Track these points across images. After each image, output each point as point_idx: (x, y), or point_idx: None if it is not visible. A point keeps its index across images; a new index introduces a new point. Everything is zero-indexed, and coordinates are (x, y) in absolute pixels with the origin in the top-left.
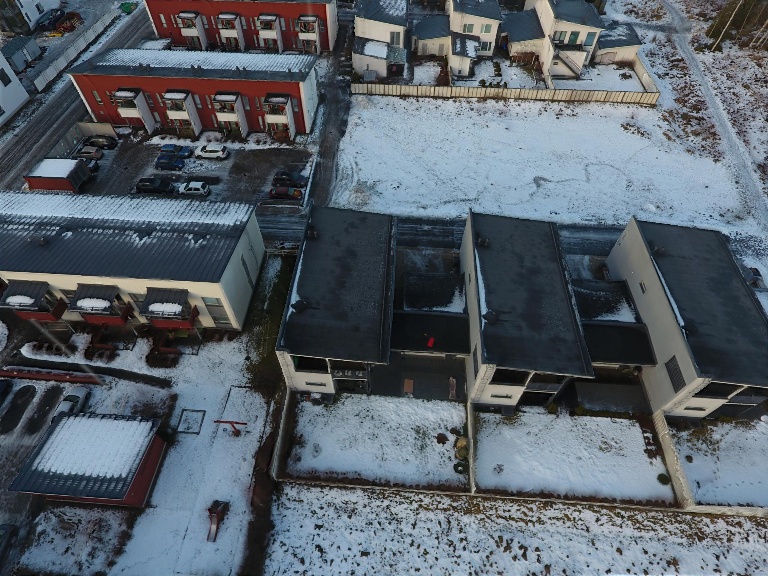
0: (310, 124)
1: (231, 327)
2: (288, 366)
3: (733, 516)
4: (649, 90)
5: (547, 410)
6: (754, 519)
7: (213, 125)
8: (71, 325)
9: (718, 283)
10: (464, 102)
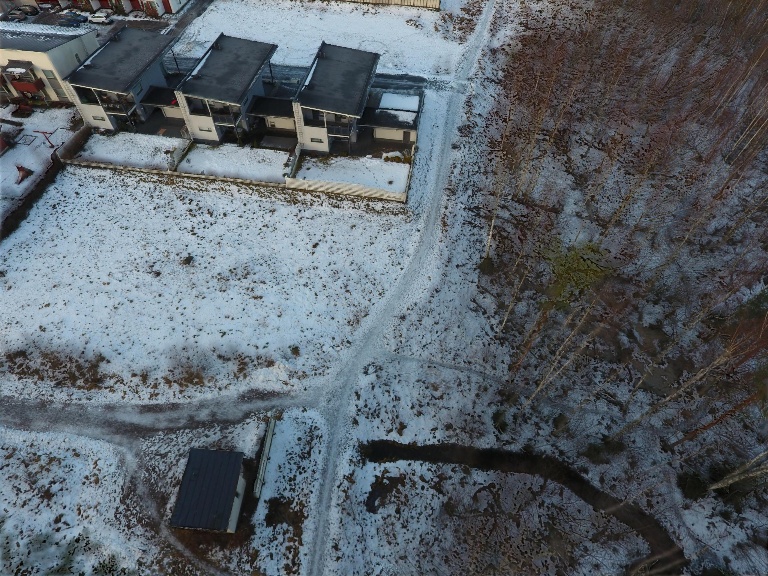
0: (178, 8)
1: (69, 101)
2: (74, 96)
3: (316, 192)
4: (443, 1)
5: (238, 145)
6: (328, 194)
7: (108, 5)
8: None
9: (351, 73)
10: (298, 1)
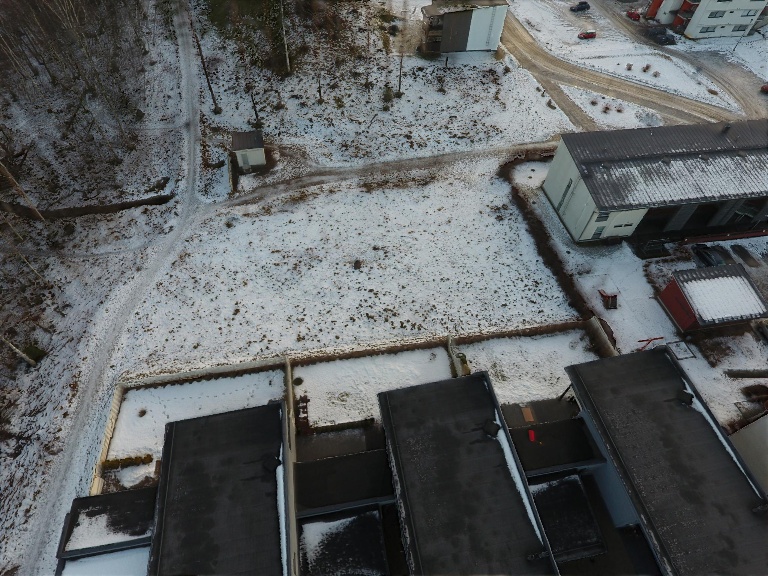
0: None
1: None
2: None
3: None
4: None
5: None
6: None
7: None
8: None
9: (199, 569)
10: None
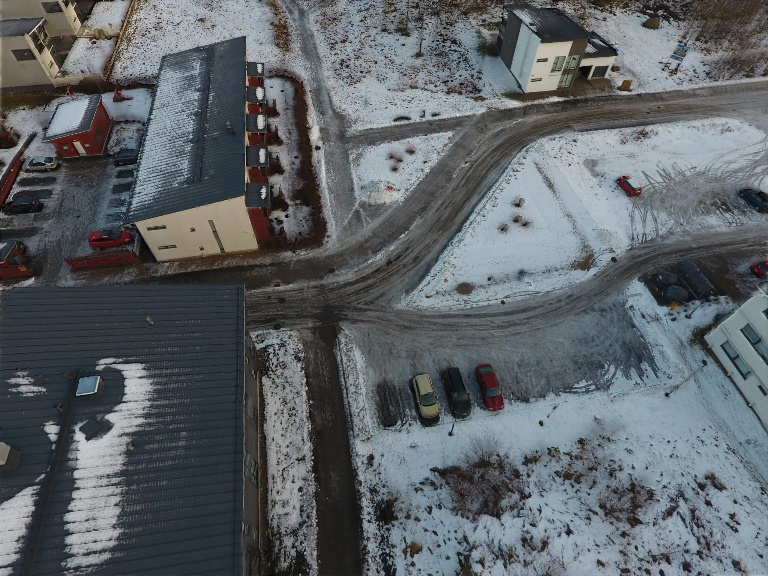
0: None
1: None
2: None
3: None
4: None
5: (86, 20)
6: None
7: None
8: None
9: None
10: None
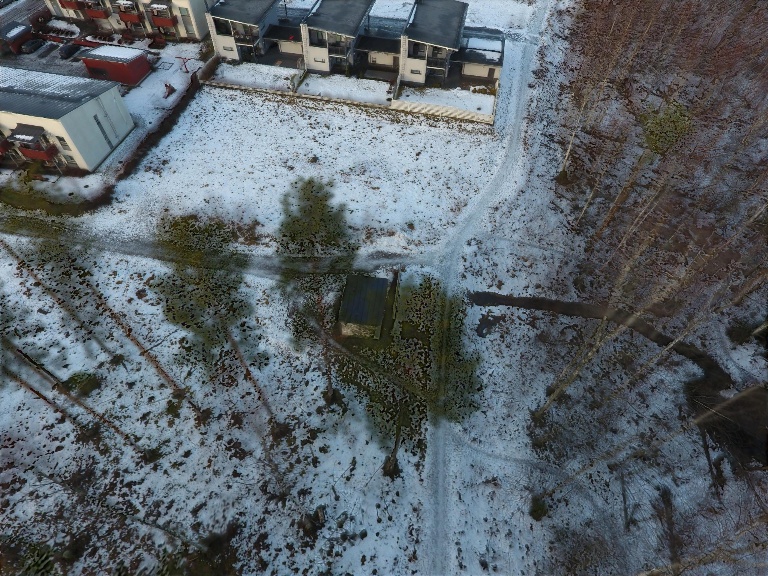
0: None
1: (195, 37)
2: (212, 27)
3: (416, 113)
4: None
5: (346, 76)
6: (426, 116)
7: None
8: (112, 28)
9: (446, 17)
10: None
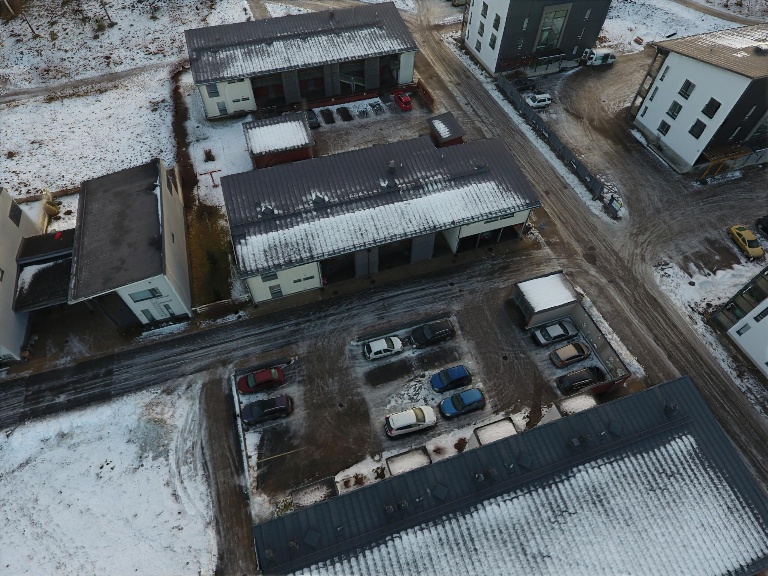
0: None
1: None
2: None
3: None
4: None
5: None
6: None
7: None
8: None
9: None
10: None
